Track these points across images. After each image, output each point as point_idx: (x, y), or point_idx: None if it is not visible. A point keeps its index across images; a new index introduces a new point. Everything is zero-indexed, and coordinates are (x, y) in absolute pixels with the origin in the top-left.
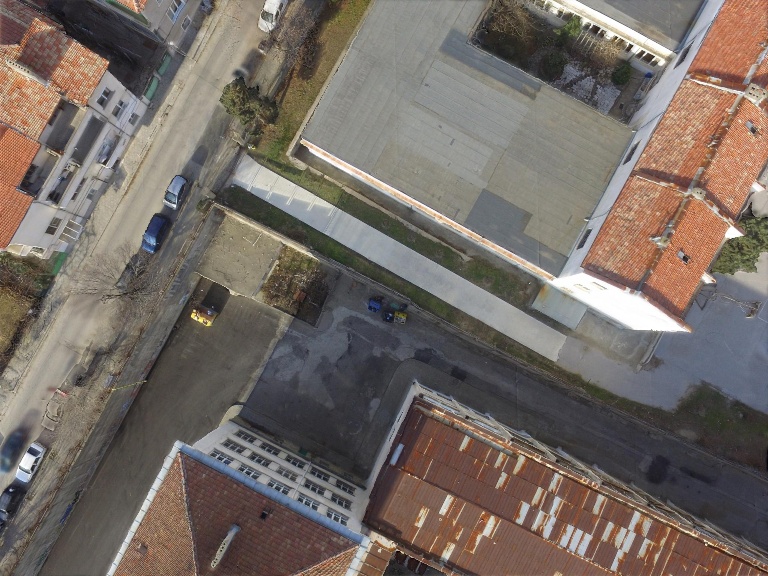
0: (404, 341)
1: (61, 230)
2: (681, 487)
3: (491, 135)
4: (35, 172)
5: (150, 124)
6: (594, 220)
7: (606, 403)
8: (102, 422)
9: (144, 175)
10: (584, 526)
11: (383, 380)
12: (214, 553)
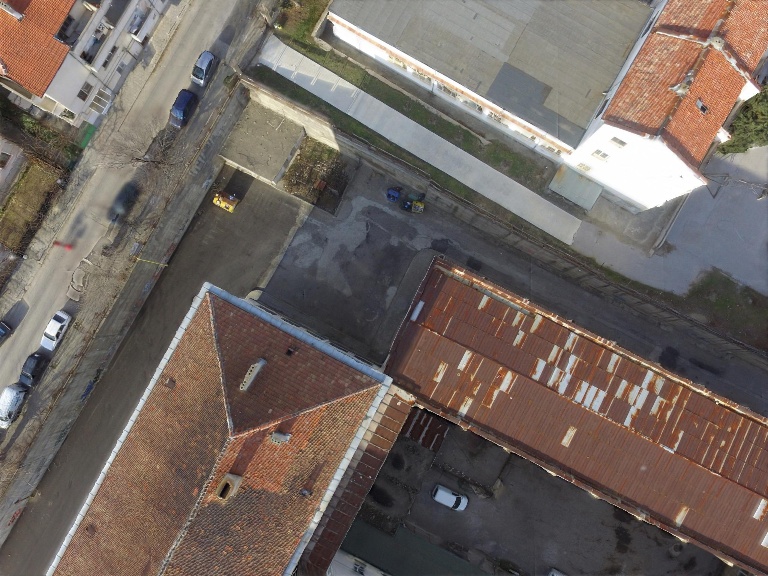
0: (421, 231)
1: (91, 98)
2: (690, 378)
3: (513, 10)
4: (71, 26)
5: (179, 3)
6: (613, 90)
7: (619, 285)
8: (126, 295)
9: (172, 53)
10: (598, 383)
11: (400, 269)
12: (242, 381)
